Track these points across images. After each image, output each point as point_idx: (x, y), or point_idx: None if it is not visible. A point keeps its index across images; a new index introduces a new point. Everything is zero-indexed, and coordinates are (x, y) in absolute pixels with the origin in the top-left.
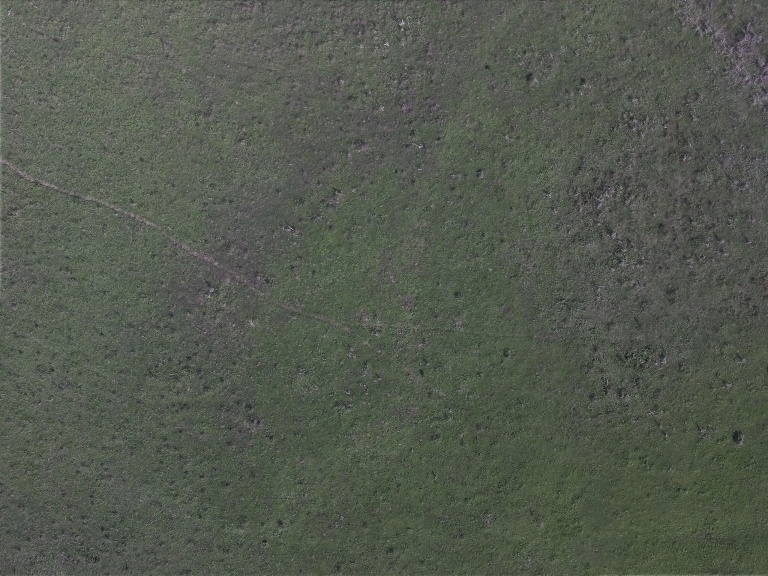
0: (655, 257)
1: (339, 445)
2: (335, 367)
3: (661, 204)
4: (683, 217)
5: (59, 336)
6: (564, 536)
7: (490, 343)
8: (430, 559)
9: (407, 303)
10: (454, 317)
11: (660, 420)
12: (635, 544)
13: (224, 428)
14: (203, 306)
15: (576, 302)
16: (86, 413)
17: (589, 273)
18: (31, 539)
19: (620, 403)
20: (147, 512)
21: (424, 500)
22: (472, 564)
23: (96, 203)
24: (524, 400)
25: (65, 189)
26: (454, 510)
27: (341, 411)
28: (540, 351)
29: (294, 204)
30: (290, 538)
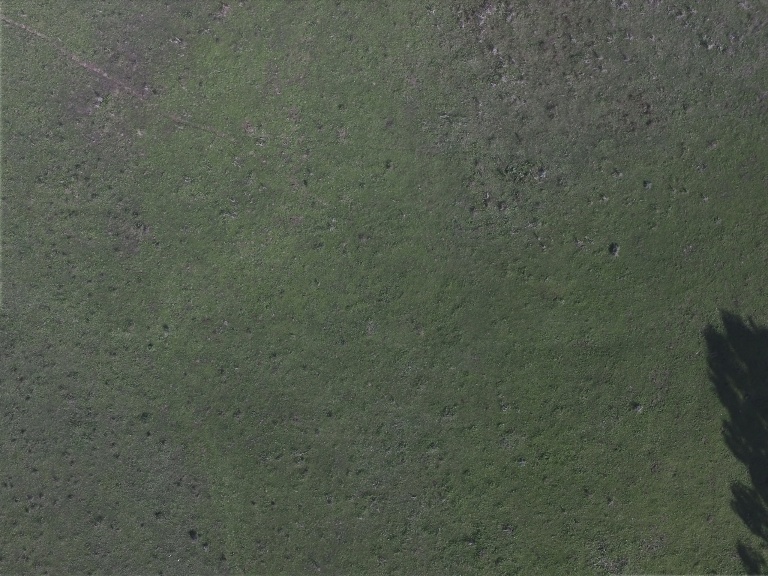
0: (536, 74)
1: (224, 252)
2: (221, 176)
3: (542, 22)
4: (563, 35)
5: None
6: (444, 344)
7: (373, 155)
8: (312, 364)
9: (292, 115)
10: (338, 129)
11: (539, 232)
12: (513, 352)
13: (112, 235)
14: (92, 116)
15: (458, 117)
16: None
17: (471, 89)
18: None
19: (500, 216)
20: (36, 316)
21: (307, 307)
22: (353, 370)
23: None
24: (406, 211)
25: None
26: (336, 317)
27: (226, 219)
28: (422, 164)
29: (182, 17)
30: (176, 342)
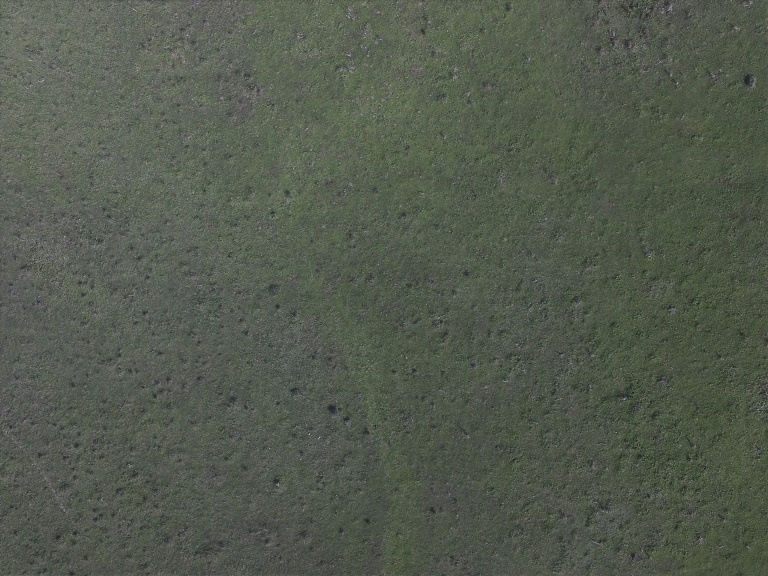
0: None
1: (343, 109)
2: (334, 31)
3: None
4: None
5: (46, 15)
6: (580, 192)
7: None
8: (444, 222)
9: None
10: None
11: (670, 69)
12: (652, 196)
13: (223, 100)
14: None
15: None
16: (79, 93)
17: None
18: (30, 225)
19: (628, 54)
20: (149, 191)
21: (434, 162)
22: (487, 225)
23: None
24: (530, 55)
25: None
26: (465, 171)
27: (343, 74)
28: (543, 5)
29: None
30: (299, 209)
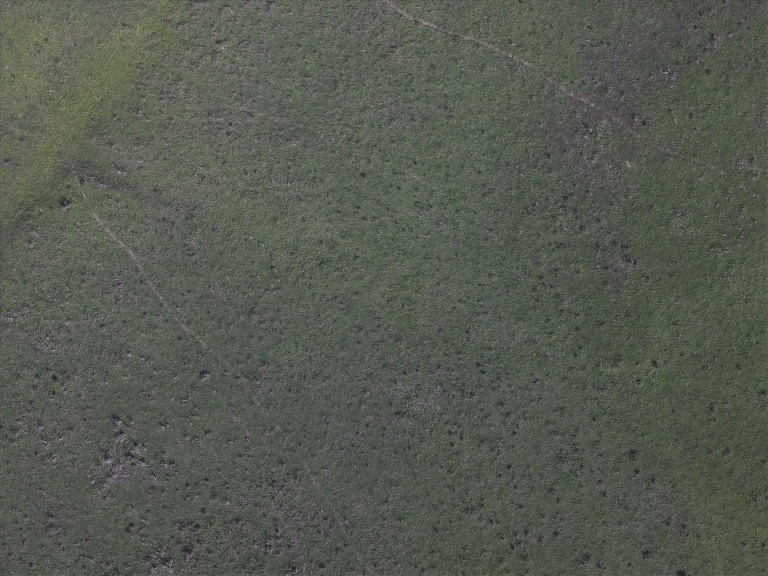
0: None
1: (714, 287)
2: (710, 210)
3: None
4: None
5: (437, 173)
6: None
7: None
8: None
9: None
10: None
11: None
12: None
13: (599, 268)
14: (580, 147)
15: None
16: (462, 250)
17: None
18: (407, 373)
19: None
20: (521, 349)
21: None
22: None
23: (475, 43)
24: None
25: (444, 28)
26: None
27: (717, 253)
28: None
29: (671, 48)
30: (663, 378)
